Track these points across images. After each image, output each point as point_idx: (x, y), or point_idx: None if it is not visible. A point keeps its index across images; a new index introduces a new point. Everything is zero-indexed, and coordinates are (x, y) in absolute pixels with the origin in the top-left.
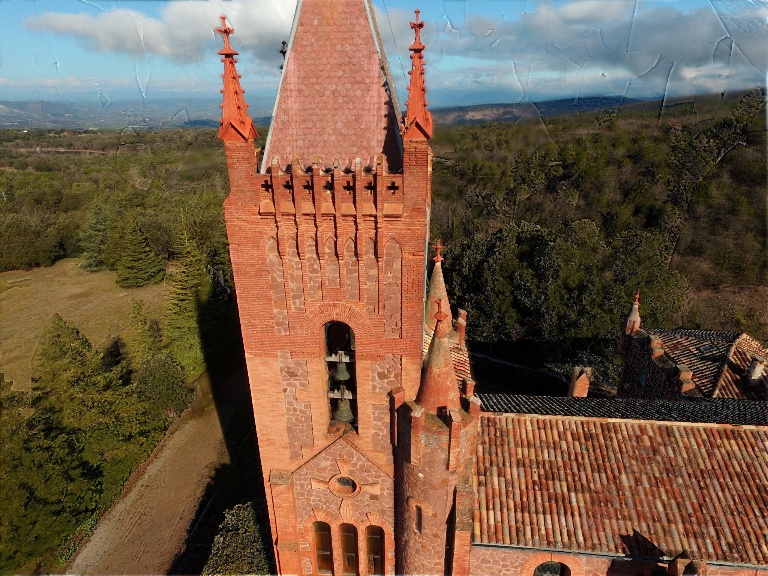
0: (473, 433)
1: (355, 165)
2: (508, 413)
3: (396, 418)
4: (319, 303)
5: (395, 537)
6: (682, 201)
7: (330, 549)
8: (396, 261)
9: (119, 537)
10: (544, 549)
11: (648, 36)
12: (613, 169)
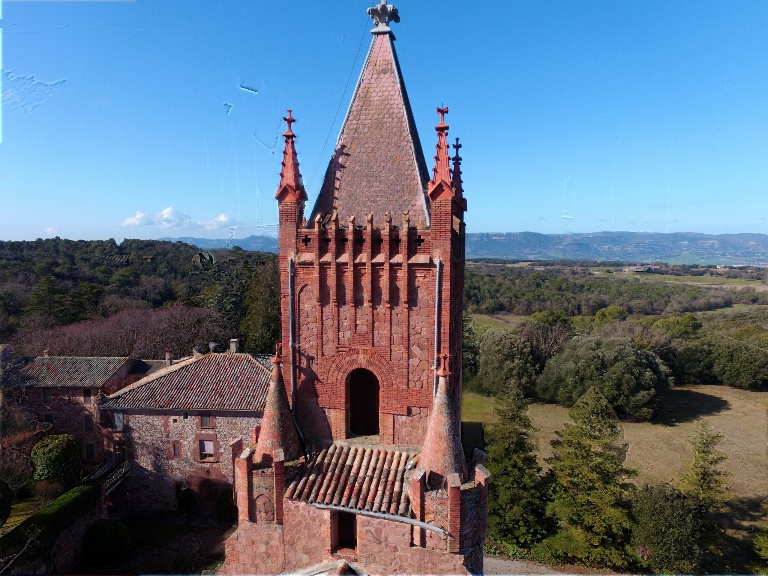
0: None
1: None
2: None
3: None
4: None
5: None
6: None
7: None
8: None
9: None
10: None
11: None
12: None
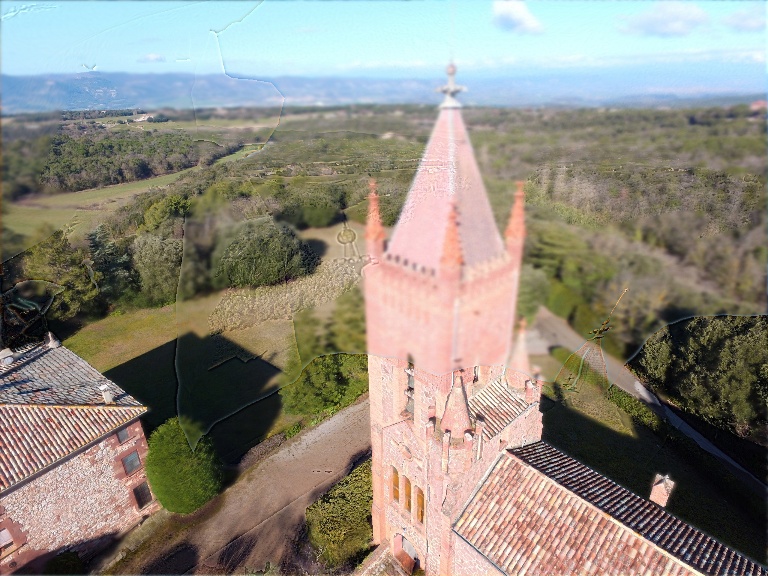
0: (465, 457)
1: None
2: (533, 468)
3: None
4: None
5: None
6: None
7: None
8: None
9: (343, 426)
10: (493, 563)
11: None
12: None
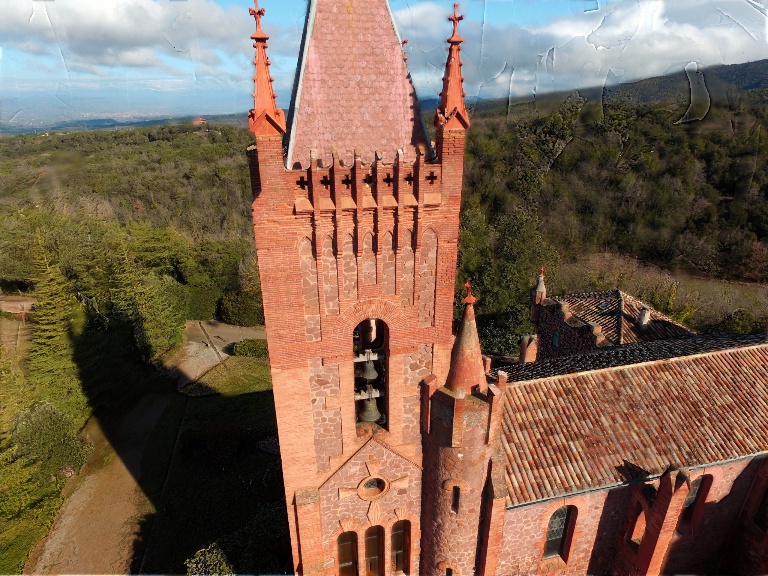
0: (501, 405)
1: (398, 156)
2: None
3: (430, 406)
4: (354, 302)
5: (421, 526)
6: (534, 187)
7: (352, 559)
8: (431, 250)
9: None
10: (563, 496)
11: (495, 44)
12: (475, 162)
